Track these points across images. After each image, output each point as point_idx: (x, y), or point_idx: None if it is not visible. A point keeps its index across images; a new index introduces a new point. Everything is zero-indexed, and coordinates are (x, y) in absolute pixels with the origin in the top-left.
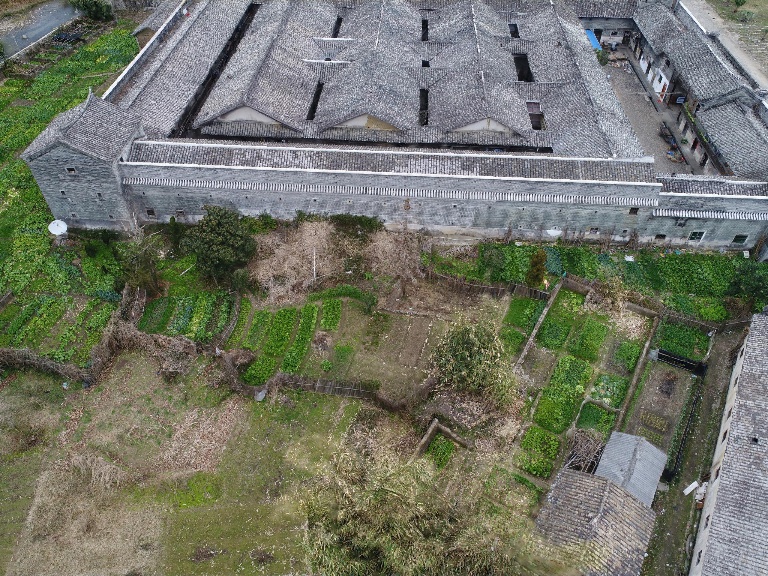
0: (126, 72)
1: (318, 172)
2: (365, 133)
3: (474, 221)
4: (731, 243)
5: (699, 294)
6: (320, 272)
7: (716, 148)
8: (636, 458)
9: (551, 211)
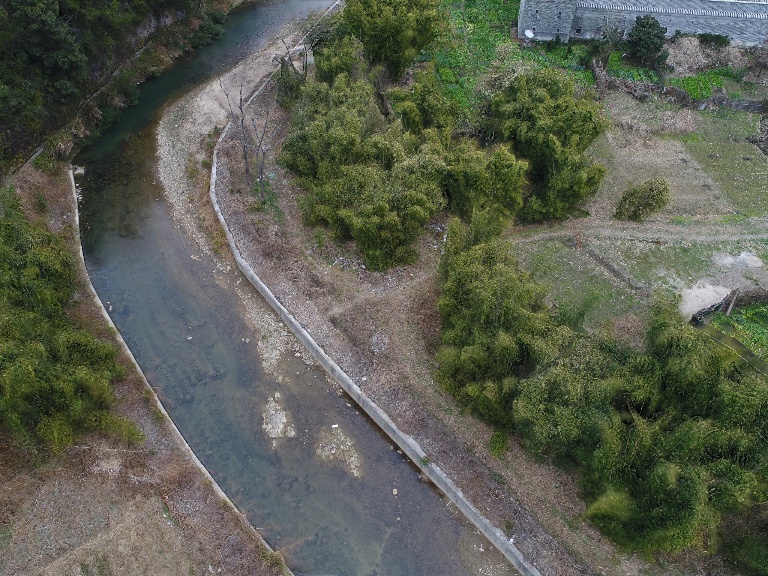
0: None
1: (704, 0)
2: None
3: None
4: None
5: None
6: (701, 62)
7: None
8: None
9: None
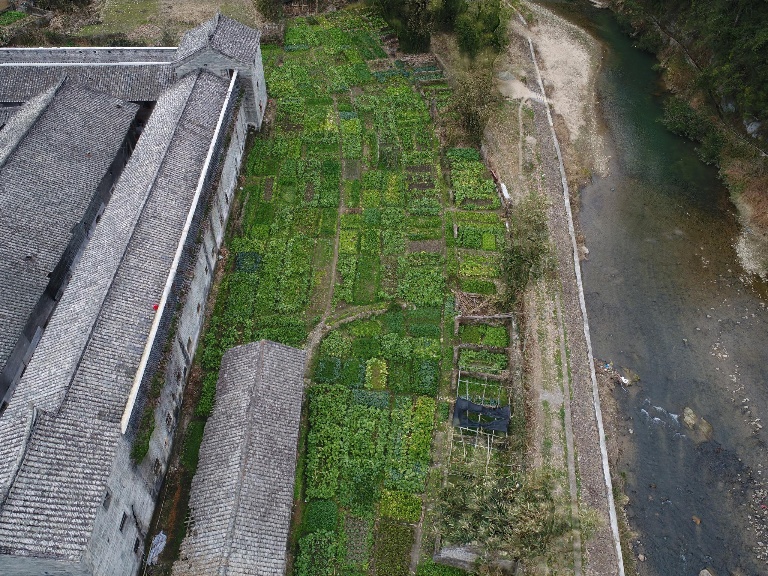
0: (216, 130)
1: None
2: None
3: None
4: None
5: None
6: None
7: None
8: None
9: None
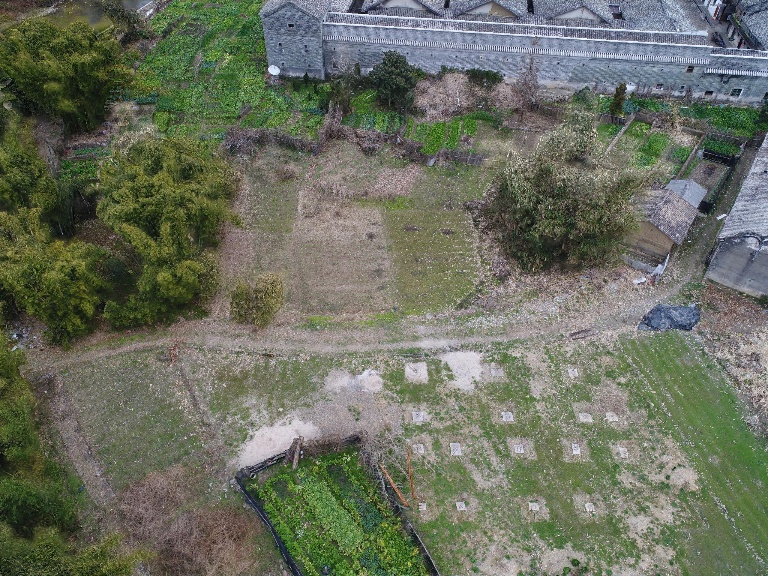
0: None
1: (463, 32)
2: (489, 18)
3: (571, 77)
4: (762, 99)
5: (735, 128)
6: None
7: (756, 39)
8: (687, 188)
9: (629, 69)
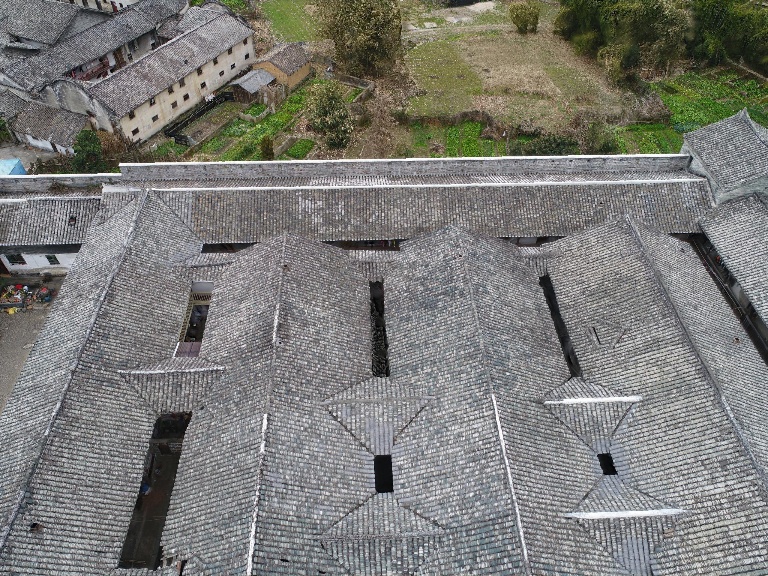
0: None
1: None
2: None
3: None
4: None
5: None
6: None
7: None
8: (247, 78)
9: None
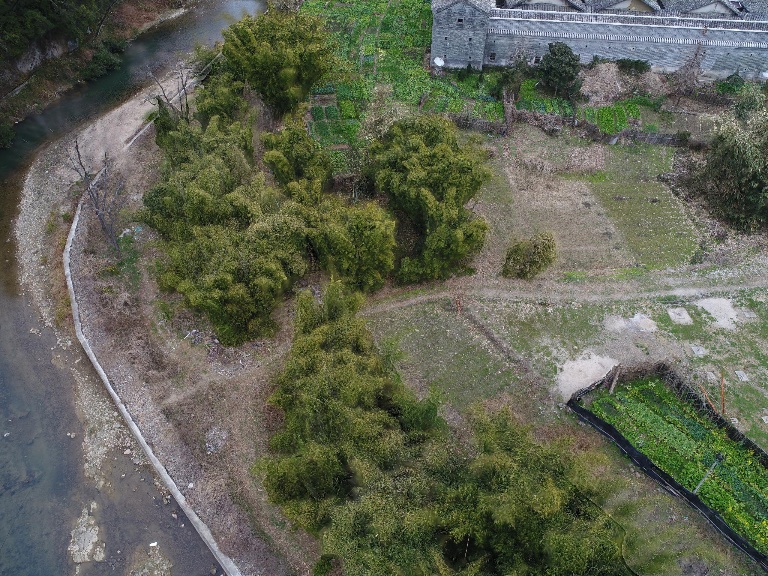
0: None
1: (620, 25)
2: (627, 13)
3: (714, 65)
4: None
5: None
6: (618, 90)
7: None
8: None
9: None
